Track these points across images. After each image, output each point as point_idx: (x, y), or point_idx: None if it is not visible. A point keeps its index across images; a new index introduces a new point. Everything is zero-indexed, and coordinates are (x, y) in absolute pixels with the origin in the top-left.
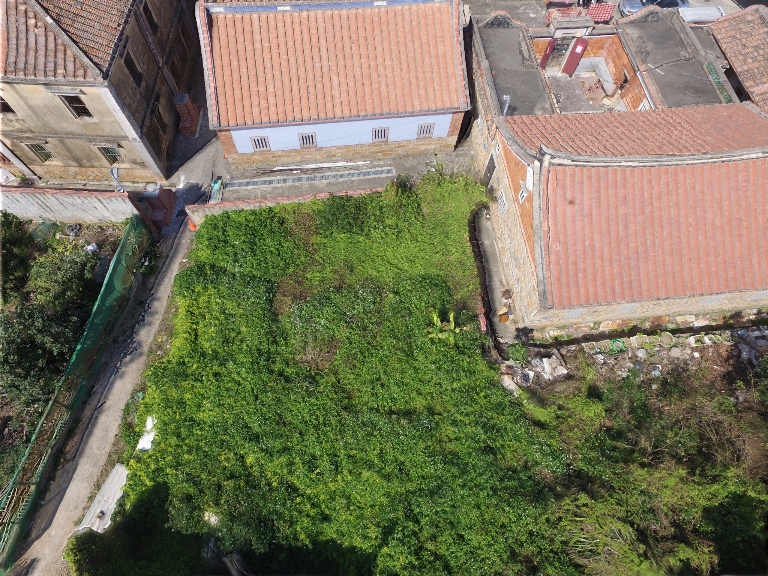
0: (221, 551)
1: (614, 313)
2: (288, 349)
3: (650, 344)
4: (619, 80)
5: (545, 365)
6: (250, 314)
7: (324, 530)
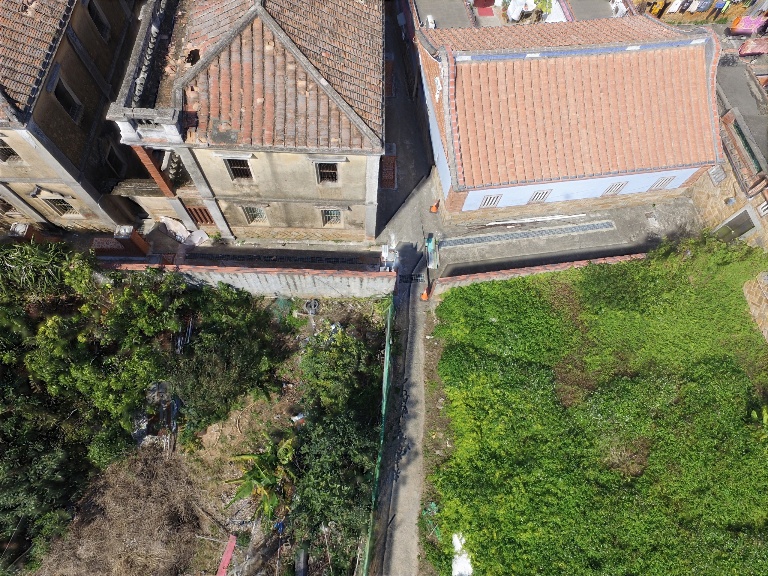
0: None
1: None
2: (593, 450)
3: None
4: None
5: None
6: (542, 409)
7: None
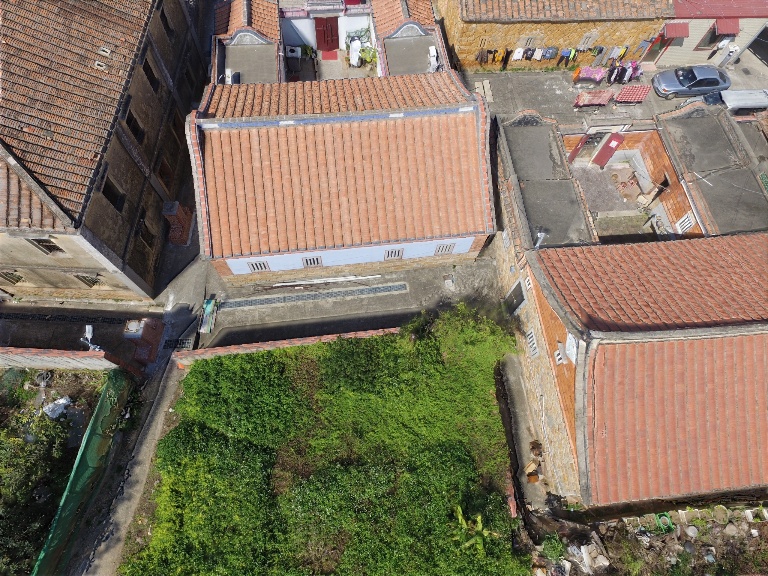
0: None
1: (664, 497)
2: (288, 545)
3: (702, 521)
4: (658, 180)
5: (584, 555)
6: (244, 499)
7: None
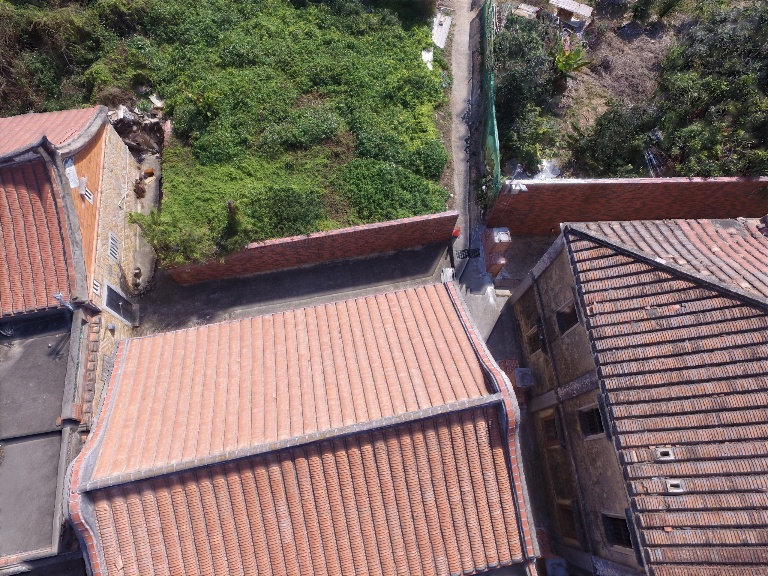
0: None
1: None
2: None
3: None
4: None
5: (122, 114)
6: None
7: None
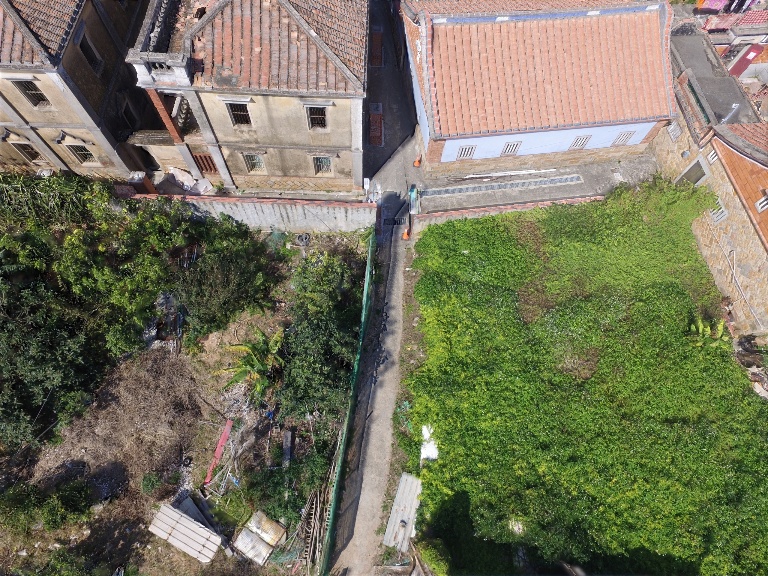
0: (546, 560)
1: None
2: (548, 358)
3: None
4: None
5: None
6: (505, 323)
7: (632, 539)
